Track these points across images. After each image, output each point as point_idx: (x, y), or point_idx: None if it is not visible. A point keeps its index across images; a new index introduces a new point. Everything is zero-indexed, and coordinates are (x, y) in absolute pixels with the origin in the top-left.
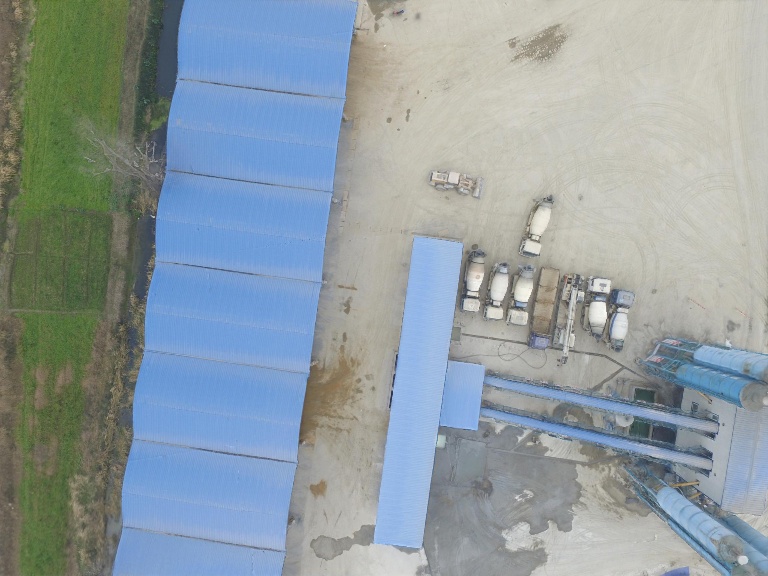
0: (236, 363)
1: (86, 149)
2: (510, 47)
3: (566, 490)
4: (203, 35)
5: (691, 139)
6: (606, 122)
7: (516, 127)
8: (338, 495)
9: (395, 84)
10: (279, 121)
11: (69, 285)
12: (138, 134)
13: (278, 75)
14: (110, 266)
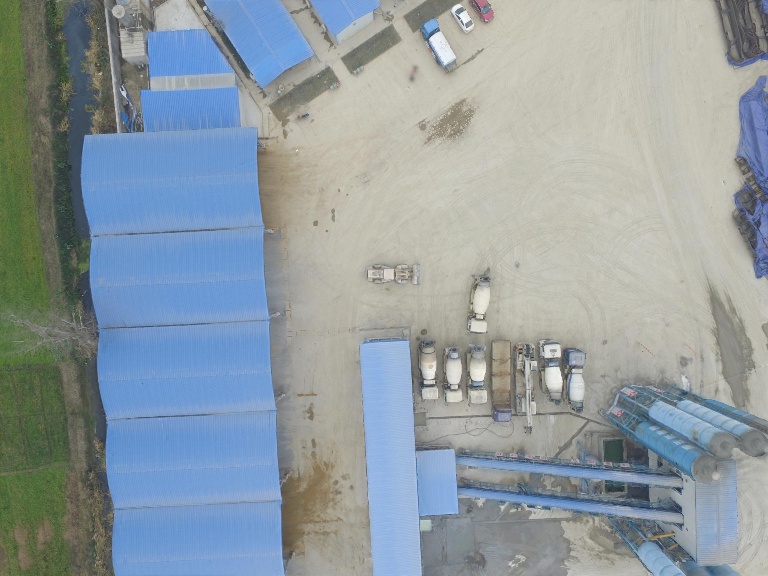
0: (208, 504)
1: (18, 305)
2: (421, 130)
3: (556, 548)
4: (107, 191)
5: (613, 188)
6: (528, 187)
7: (442, 207)
8: None
9: (315, 186)
10: (202, 262)
11: (30, 443)
12: (68, 281)
13: (192, 215)
14: (67, 416)
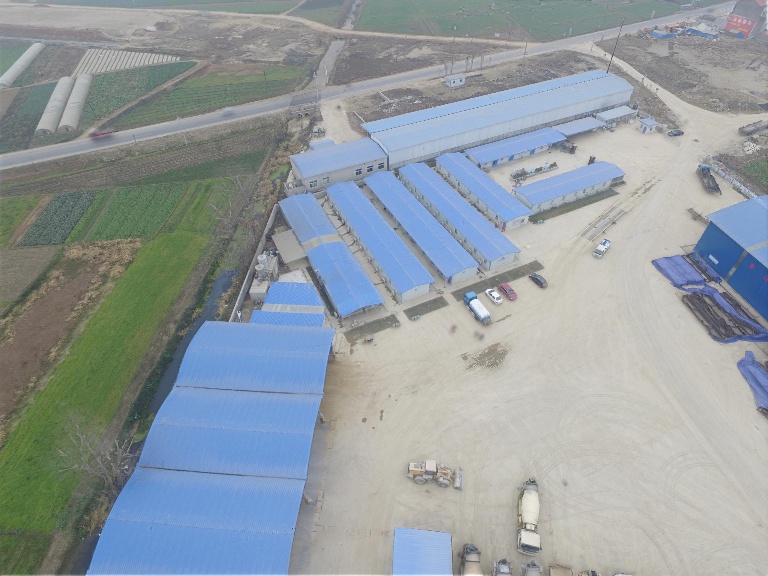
0: None
1: (58, 464)
2: (463, 359)
3: None
4: (206, 352)
5: (647, 422)
6: (564, 411)
7: (483, 420)
8: None
9: (369, 391)
10: (260, 414)
11: None
12: None
13: (265, 378)
14: None
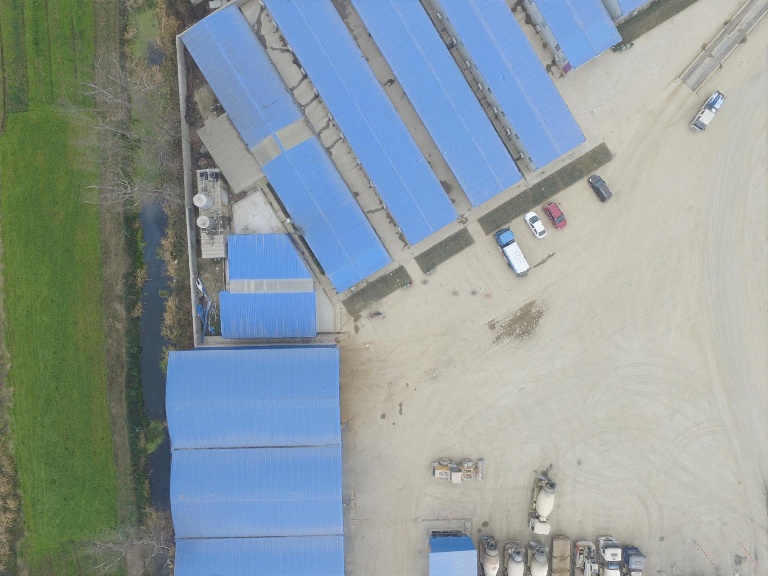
0: None
1: (85, 484)
2: (490, 329)
3: None
4: (191, 411)
5: (676, 391)
6: (593, 387)
7: (507, 405)
8: None
9: (383, 380)
10: (281, 481)
11: None
12: (135, 463)
13: (272, 434)
14: None
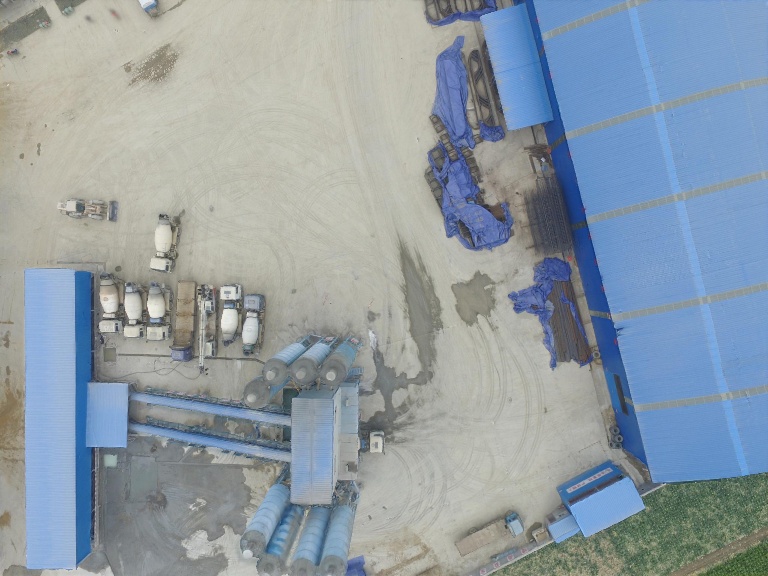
0: None
1: None
2: (126, 71)
3: (236, 494)
4: None
5: (309, 139)
6: (226, 133)
7: (142, 148)
8: (22, 524)
9: (23, 121)
10: None
11: None
12: None
13: None
14: None
